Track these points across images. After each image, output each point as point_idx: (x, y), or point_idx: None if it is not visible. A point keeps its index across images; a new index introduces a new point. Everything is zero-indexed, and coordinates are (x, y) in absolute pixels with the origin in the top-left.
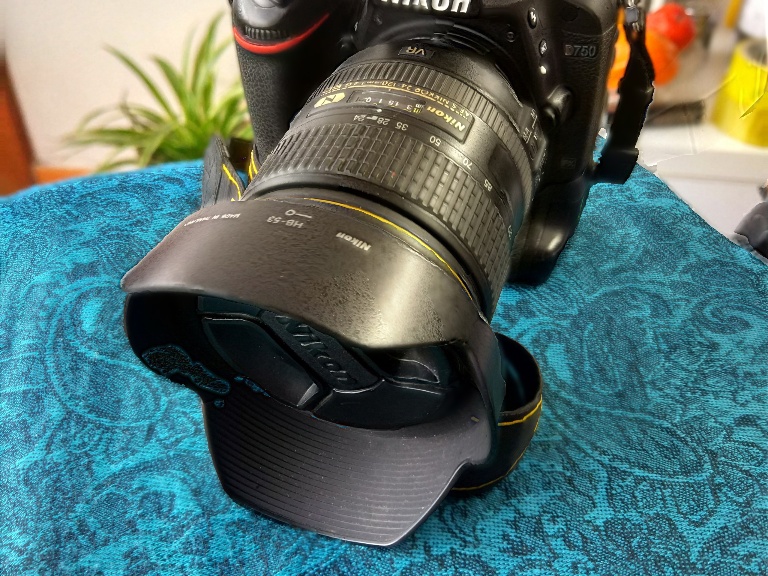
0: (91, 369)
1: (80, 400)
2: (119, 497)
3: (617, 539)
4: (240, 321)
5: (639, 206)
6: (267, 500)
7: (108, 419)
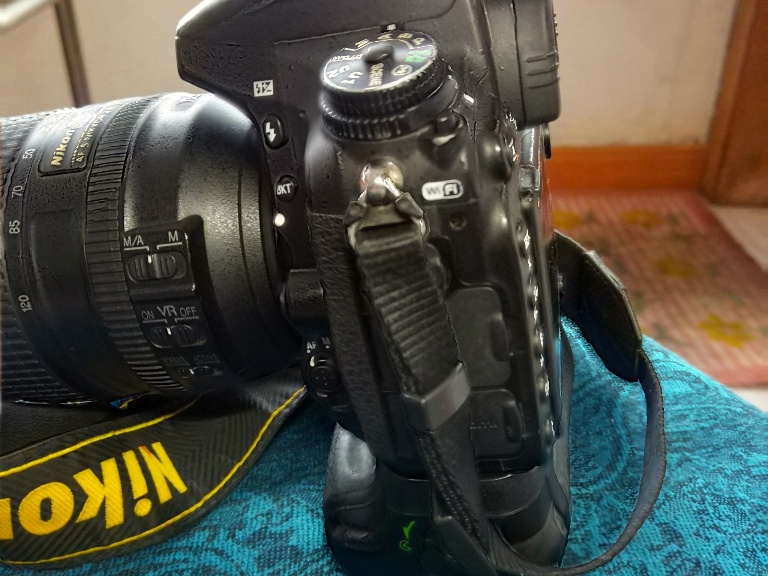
0: None
1: None
2: None
3: None
4: None
5: None
6: None
7: None
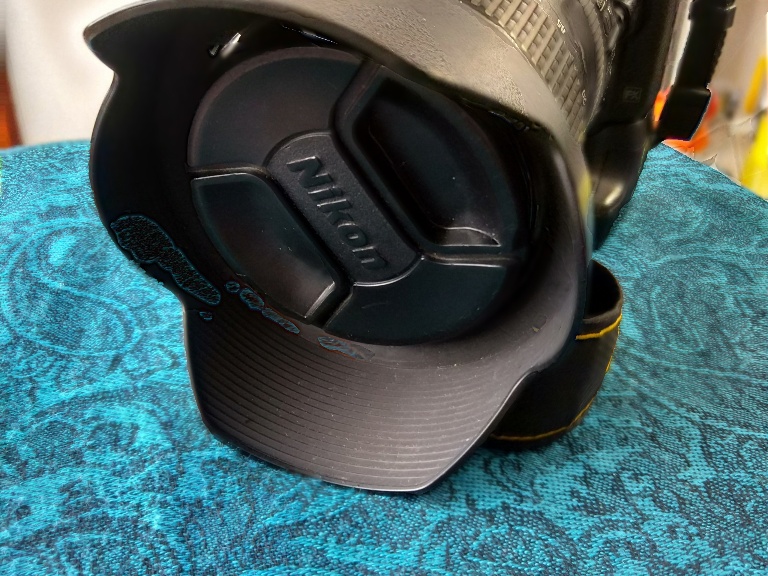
0: (52, 298)
1: (33, 327)
2: (65, 426)
3: (724, 502)
4: (240, 176)
5: (698, 188)
6: (259, 438)
7: (65, 347)
